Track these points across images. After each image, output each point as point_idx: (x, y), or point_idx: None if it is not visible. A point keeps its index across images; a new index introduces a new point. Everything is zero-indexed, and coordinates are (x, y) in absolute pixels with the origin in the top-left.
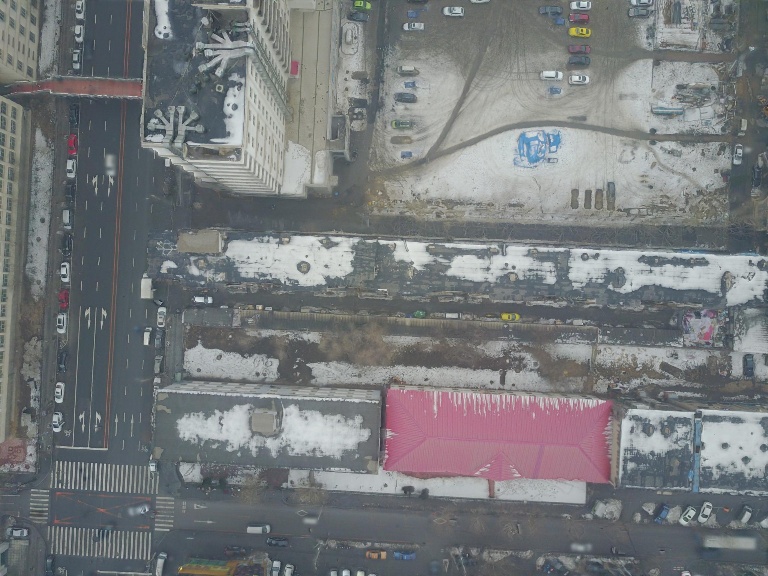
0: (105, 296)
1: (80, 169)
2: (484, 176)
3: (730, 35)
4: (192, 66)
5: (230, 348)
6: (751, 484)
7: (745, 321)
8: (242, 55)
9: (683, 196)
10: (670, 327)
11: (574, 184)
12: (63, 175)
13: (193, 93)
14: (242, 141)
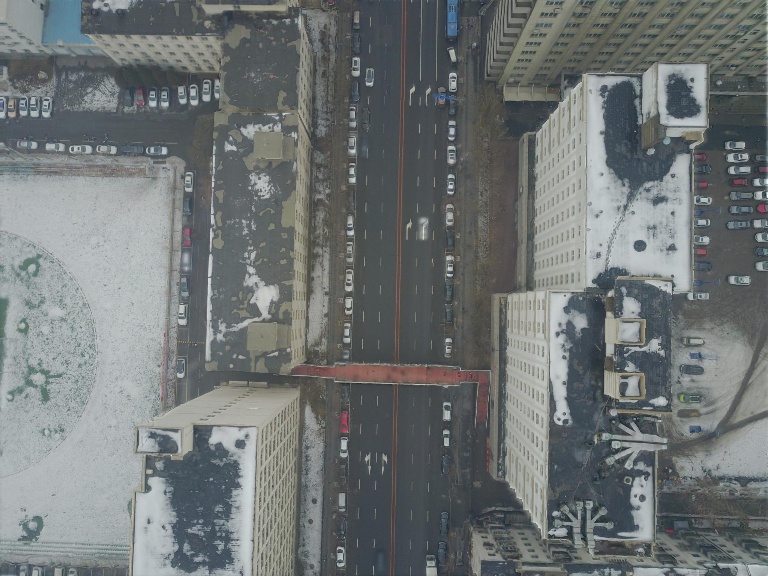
0: None
1: (352, 446)
2: None
3: None
4: (594, 454)
5: None
6: None
7: None
8: None
9: None
10: None
11: None
12: (335, 454)
13: None
14: (653, 536)
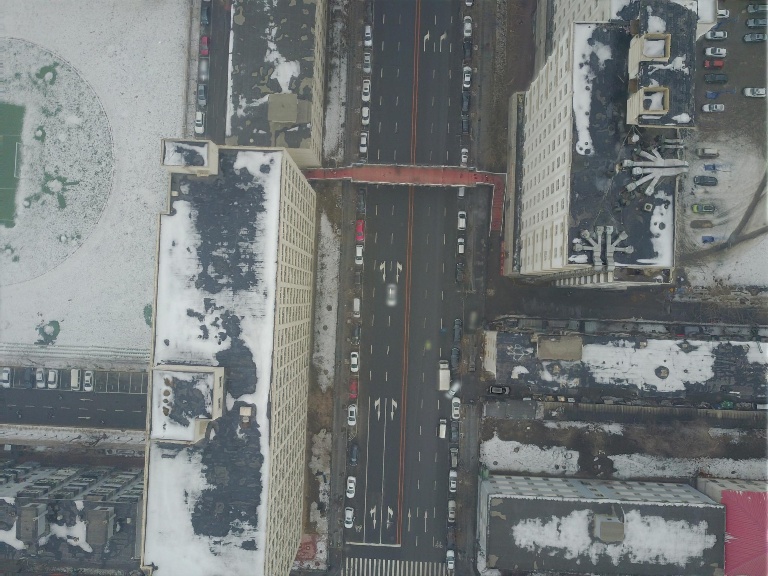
0: (395, 386)
1: (367, 255)
2: None
3: None
4: (615, 183)
5: (528, 440)
6: None
7: None
8: (677, 174)
9: None
10: None
11: None
12: (350, 262)
13: (617, 211)
14: (672, 262)
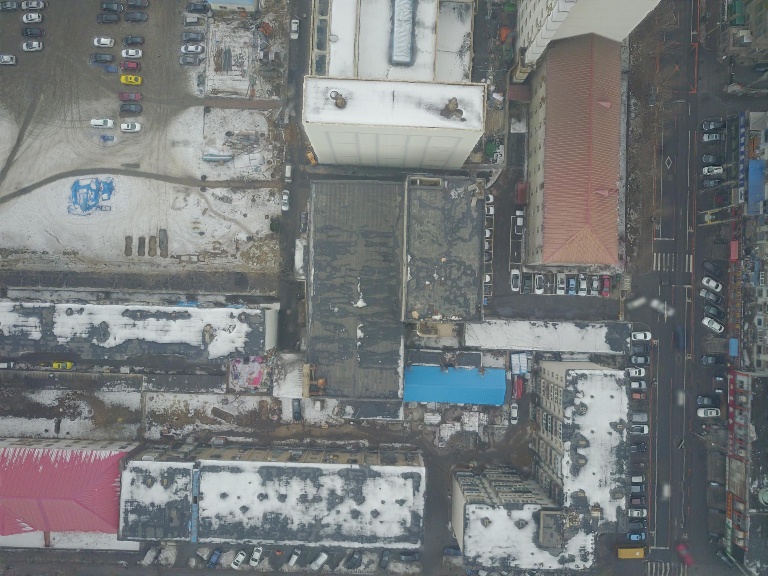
0: None
1: None
2: (39, 224)
3: (279, 82)
4: None
5: None
6: (249, 533)
7: (283, 367)
8: None
9: (234, 242)
10: (220, 373)
11: (128, 231)
12: None
13: None
14: None
